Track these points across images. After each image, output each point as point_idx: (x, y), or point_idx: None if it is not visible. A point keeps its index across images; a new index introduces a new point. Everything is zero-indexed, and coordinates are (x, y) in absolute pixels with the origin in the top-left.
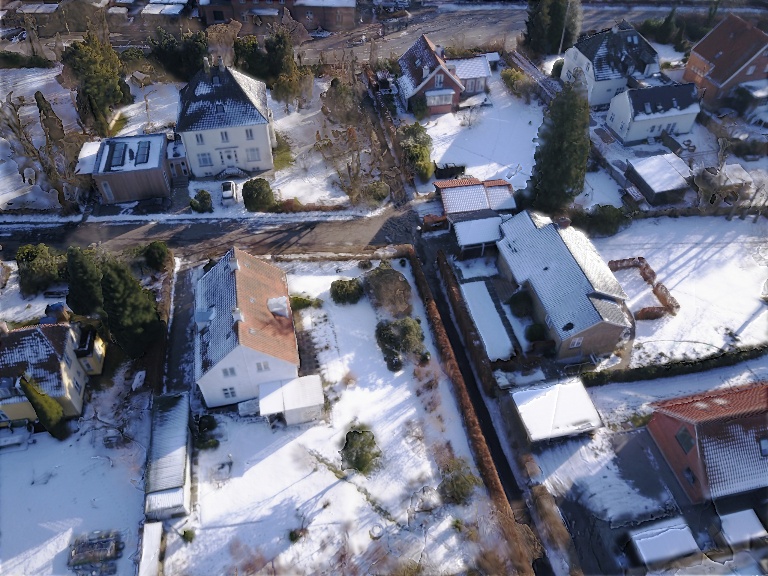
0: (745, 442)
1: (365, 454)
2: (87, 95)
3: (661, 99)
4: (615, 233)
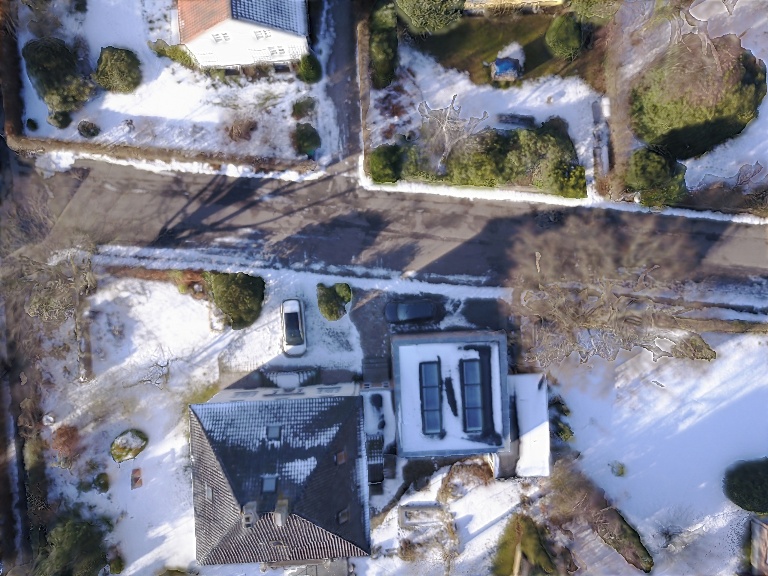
0: None
1: None
2: (556, 572)
3: None
4: None
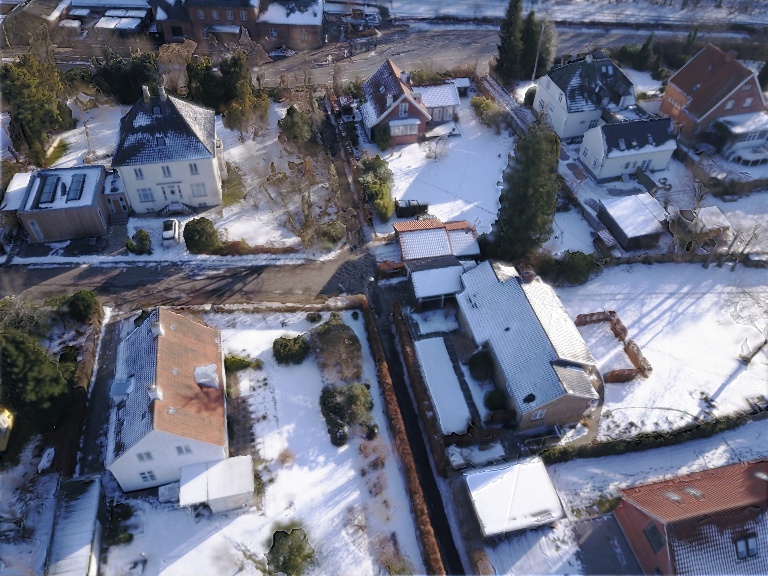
0: (720, 544)
1: (294, 558)
2: (19, 122)
3: (636, 135)
4: (585, 282)
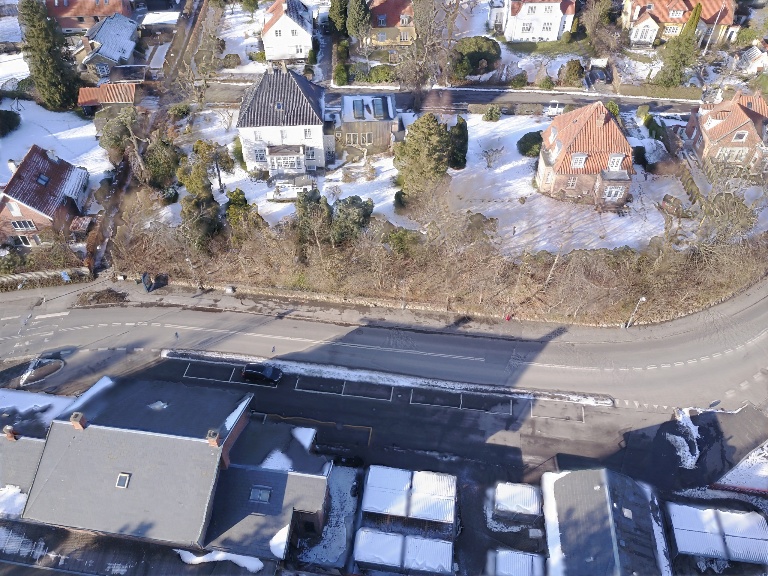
0: None
1: None
2: None
3: None
4: None
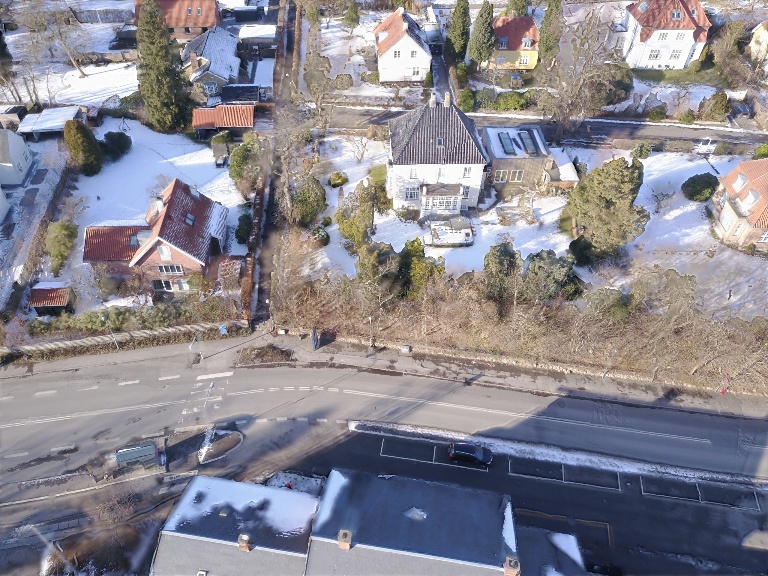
0: None
1: None
2: None
3: None
4: None
